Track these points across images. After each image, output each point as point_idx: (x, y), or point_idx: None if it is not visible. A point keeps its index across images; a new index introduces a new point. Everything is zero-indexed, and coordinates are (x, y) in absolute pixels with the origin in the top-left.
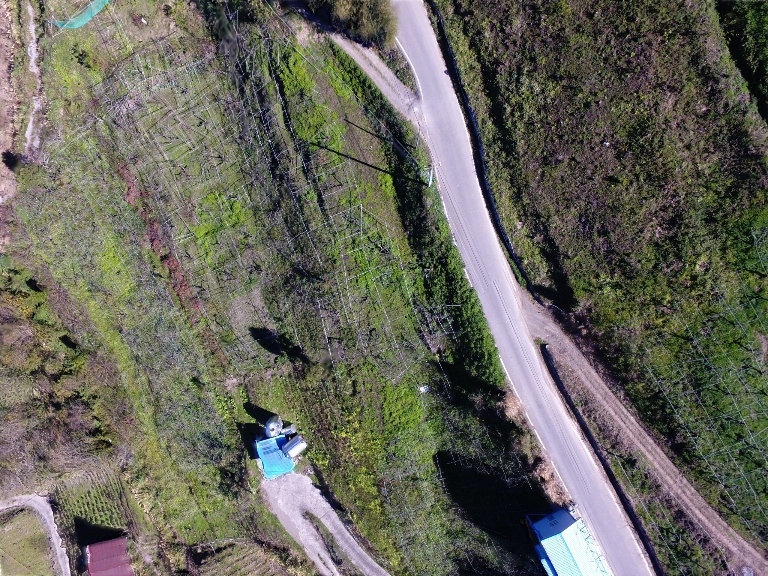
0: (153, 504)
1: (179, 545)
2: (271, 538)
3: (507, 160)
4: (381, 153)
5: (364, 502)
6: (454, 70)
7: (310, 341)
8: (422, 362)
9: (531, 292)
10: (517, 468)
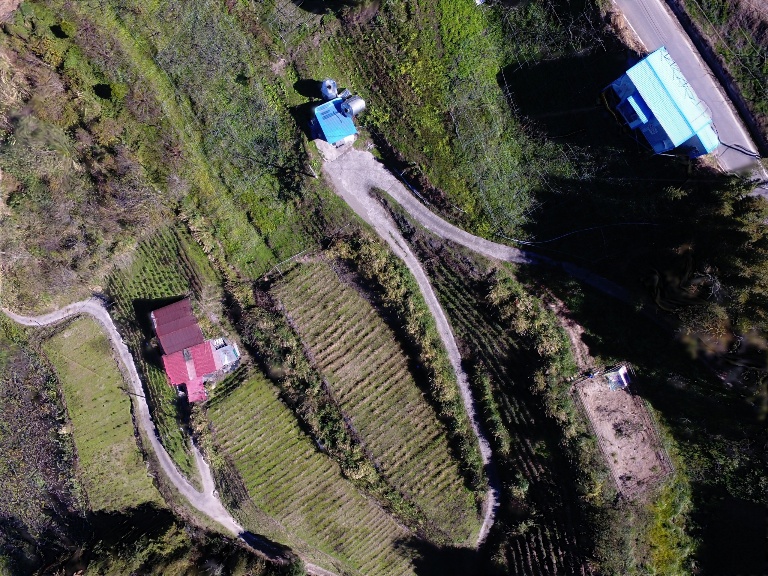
0: (213, 244)
1: (245, 283)
2: (340, 225)
3: None
4: None
5: (432, 145)
6: None
7: None
8: None
9: None
10: (589, 32)
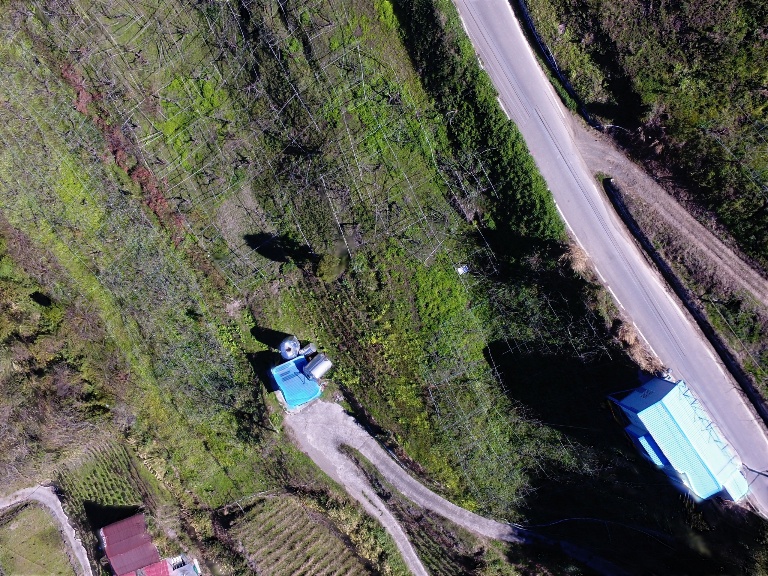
0: (166, 469)
1: (202, 511)
2: (305, 481)
3: None
4: None
5: (408, 418)
6: None
7: (318, 235)
8: (457, 236)
9: (583, 116)
10: (591, 338)
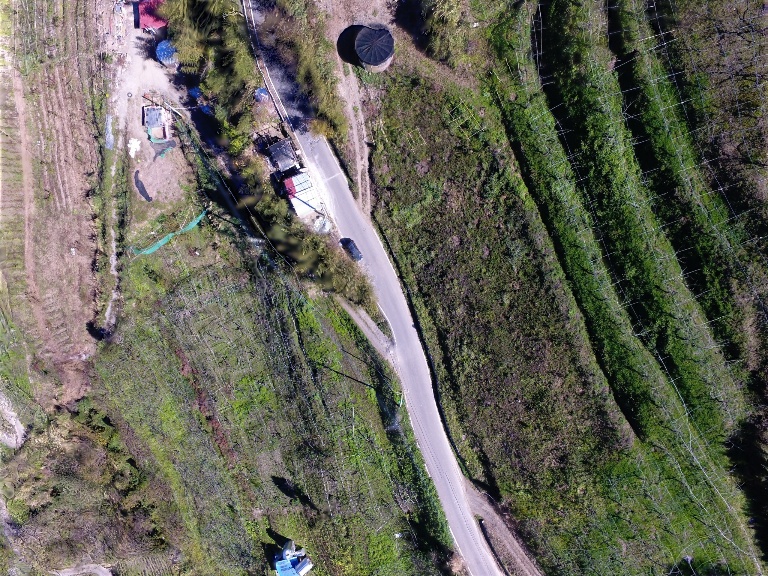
0: None
1: None
2: None
3: (454, 395)
4: (367, 374)
5: None
6: (419, 326)
7: (316, 494)
8: (397, 517)
9: (472, 482)
10: None
